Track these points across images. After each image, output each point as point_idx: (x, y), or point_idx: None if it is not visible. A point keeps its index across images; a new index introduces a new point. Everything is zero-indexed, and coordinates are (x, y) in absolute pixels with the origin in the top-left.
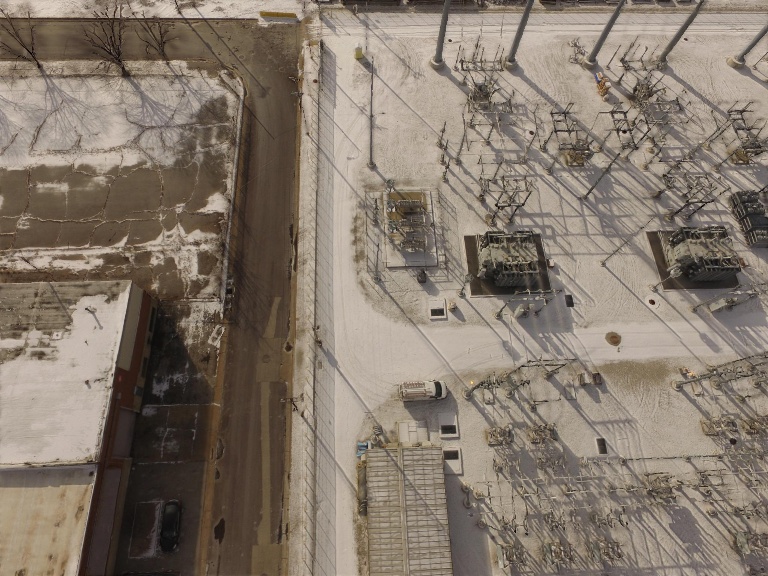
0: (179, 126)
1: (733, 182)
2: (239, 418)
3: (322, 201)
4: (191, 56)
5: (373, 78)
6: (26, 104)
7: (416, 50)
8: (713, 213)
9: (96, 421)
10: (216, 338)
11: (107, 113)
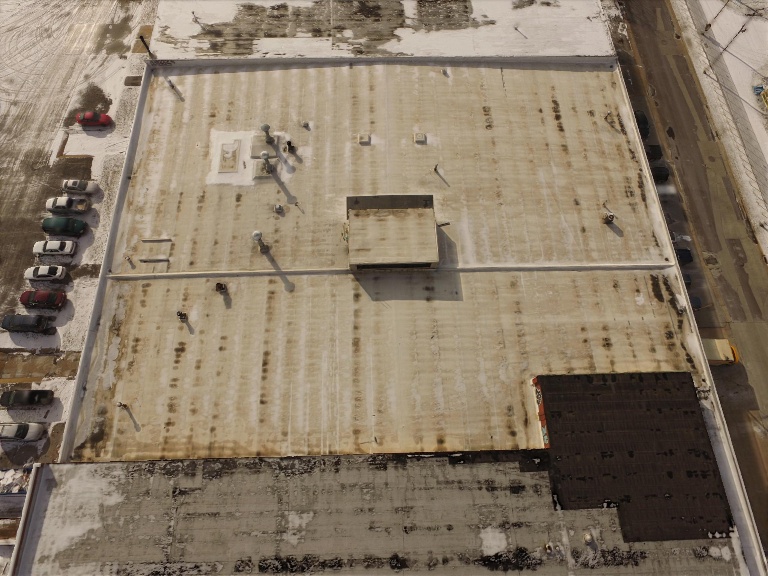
0: None
1: None
2: (659, 74)
3: None
4: None
5: None
6: None
7: None
8: None
9: (605, 37)
10: (623, 30)
11: None
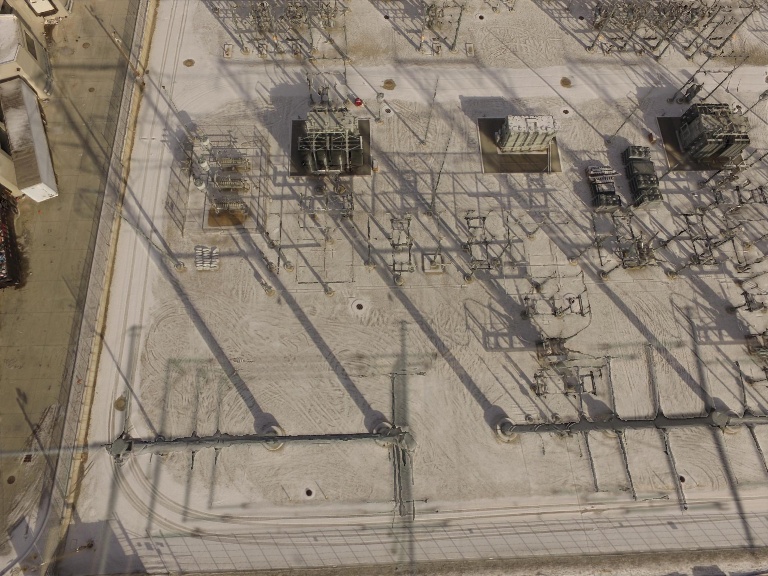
0: None
1: (645, 227)
2: None
3: None
4: None
5: None
6: None
7: None
8: (673, 190)
9: None
10: None
11: None
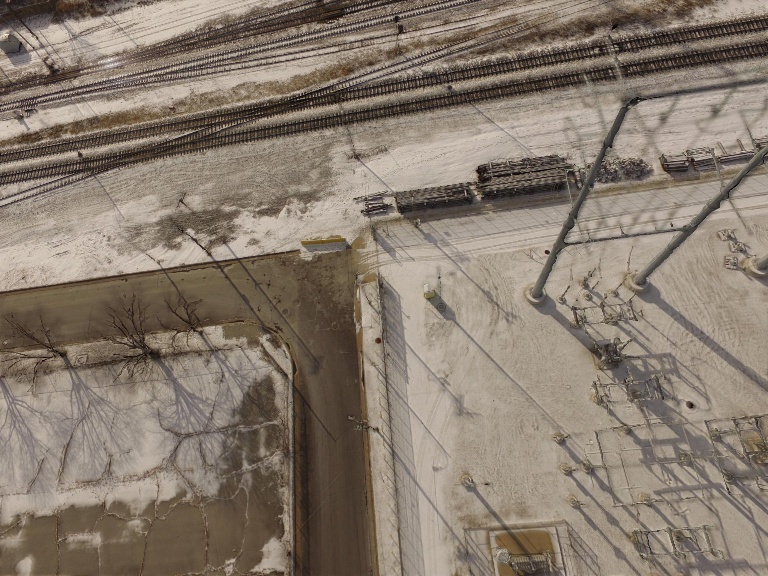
0: (220, 431)
1: None
2: None
3: (407, 546)
4: (227, 317)
5: (452, 328)
6: (51, 413)
7: (503, 275)
8: None
9: None
10: None
11: (138, 417)
